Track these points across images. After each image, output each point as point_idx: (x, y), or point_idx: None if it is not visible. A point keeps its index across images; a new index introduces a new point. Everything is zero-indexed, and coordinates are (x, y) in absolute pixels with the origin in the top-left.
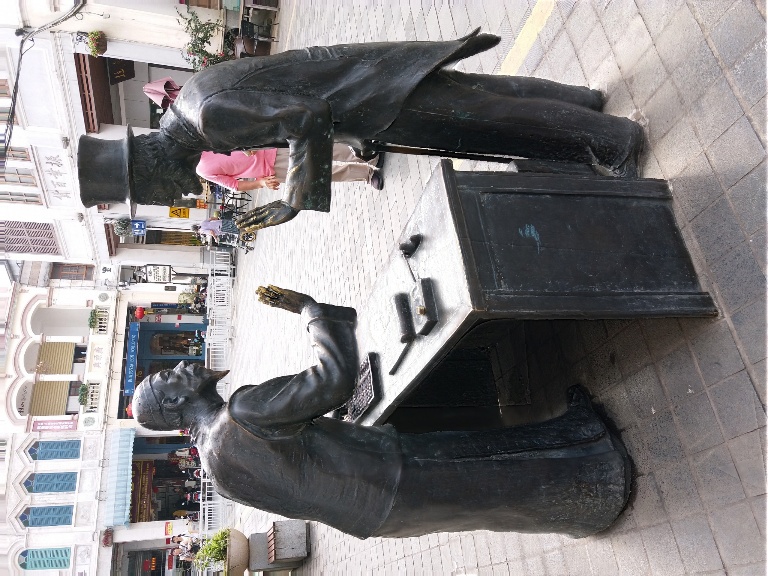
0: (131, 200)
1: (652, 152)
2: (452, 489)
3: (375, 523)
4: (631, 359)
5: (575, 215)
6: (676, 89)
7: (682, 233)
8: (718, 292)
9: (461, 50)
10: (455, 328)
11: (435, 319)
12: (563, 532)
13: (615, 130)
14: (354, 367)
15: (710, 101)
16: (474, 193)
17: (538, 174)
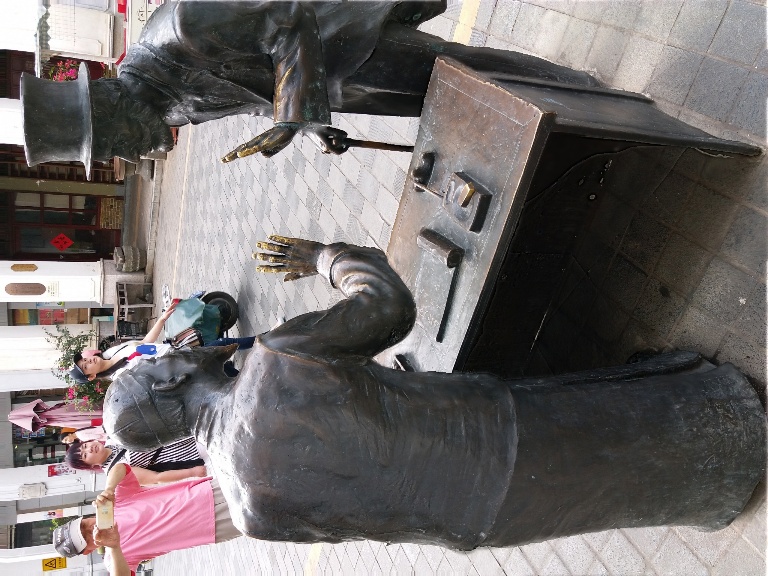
0: (92, 129)
1: (613, 86)
2: (579, 413)
3: (500, 482)
4: (687, 273)
5: None
6: (611, 27)
7: (680, 119)
8: (749, 134)
9: None
10: (523, 165)
11: (488, 194)
12: (714, 504)
13: (573, 73)
14: (406, 288)
15: (650, 8)
16: None
17: None
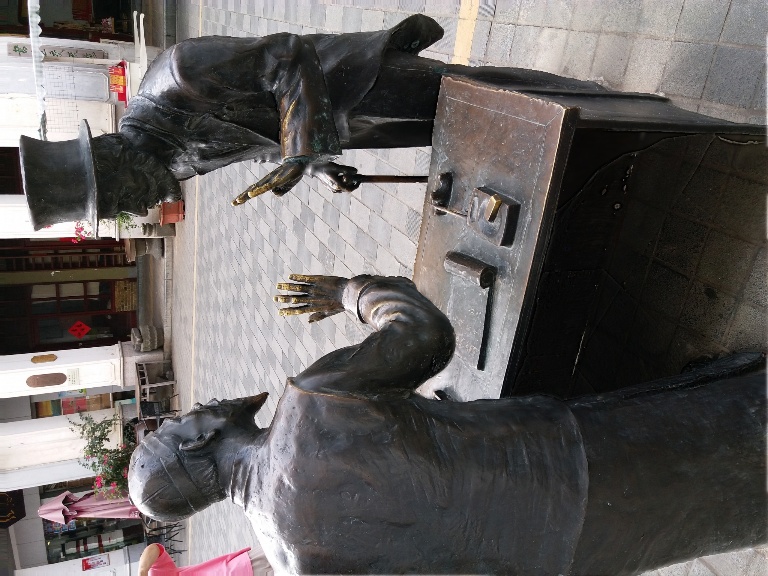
0: (96, 183)
1: None
2: (649, 428)
3: (574, 514)
4: (732, 271)
5: (597, 103)
6: (613, 33)
7: (700, 113)
8: None
9: (416, 18)
10: (551, 166)
11: (516, 204)
12: None
13: (580, 83)
14: None
15: (651, 8)
16: None
17: None
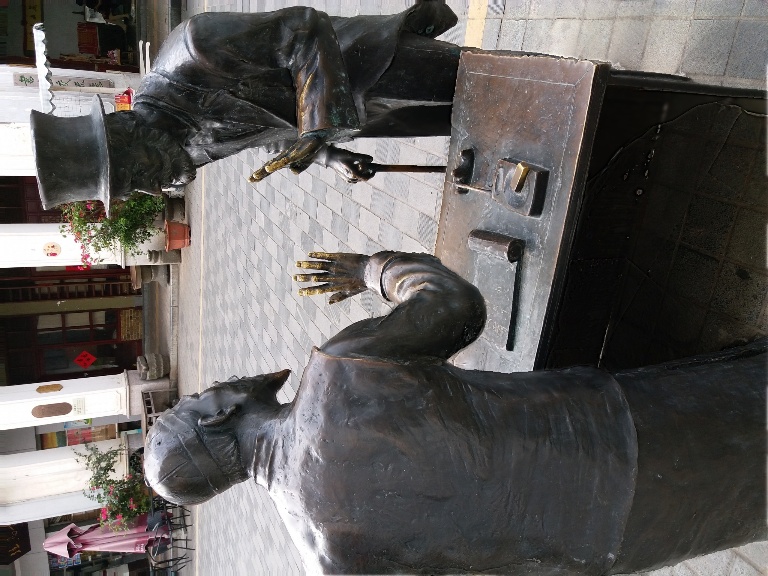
0: (108, 156)
1: None
2: (696, 397)
3: (623, 485)
4: (765, 248)
5: None
6: (628, 18)
7: None
8: None
9: (431, 1)
10: (582, 127)
11: (544, 171)
12: None
13: None
14: None
15: None
16: None
17: None
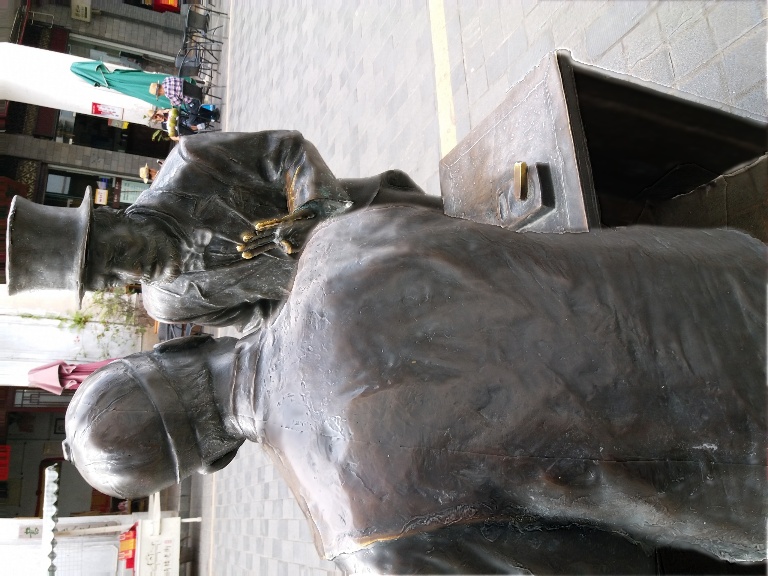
0: (90, 219)
1: None
2: None
3: None
4: None
5: None
6: None
7: None
8: None
9: (408, 173)
10: (563, 100)
11: None
12: None
13: None
14: None
15: None
16: None
17: None
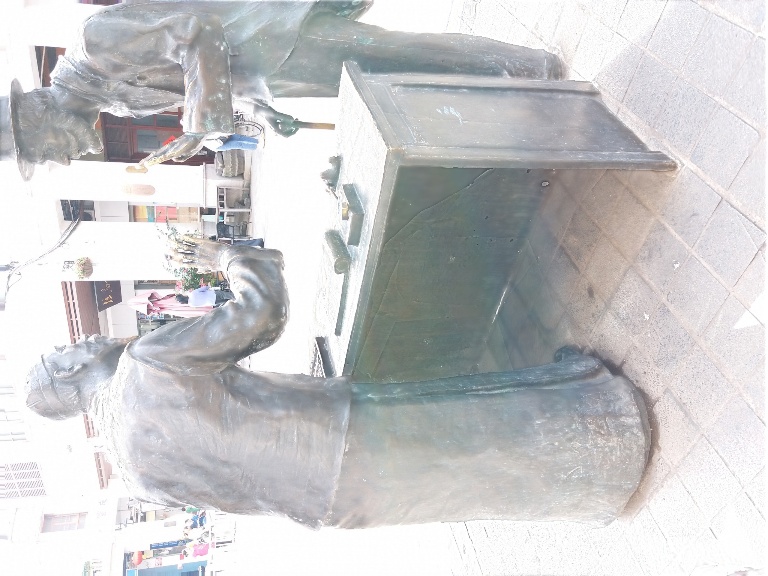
0: (16, 144)
1: (571, 69)
2: (420, 426)
3: (328, 483)
4: (608, 278)
5: (498, 103)
6: (575, 2)
7: (618, 117)
8: (670, 145)
9: None
10: (378, 194)
11: (361, 213)
12: (585, 508)
13: (528, 55)
14: (281, 297)
15: None
16: (383, 85)
17: (451, 75)
